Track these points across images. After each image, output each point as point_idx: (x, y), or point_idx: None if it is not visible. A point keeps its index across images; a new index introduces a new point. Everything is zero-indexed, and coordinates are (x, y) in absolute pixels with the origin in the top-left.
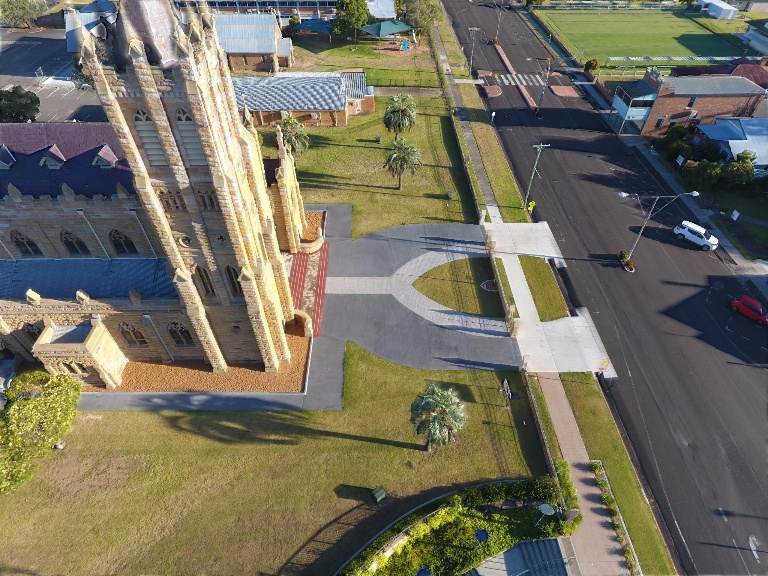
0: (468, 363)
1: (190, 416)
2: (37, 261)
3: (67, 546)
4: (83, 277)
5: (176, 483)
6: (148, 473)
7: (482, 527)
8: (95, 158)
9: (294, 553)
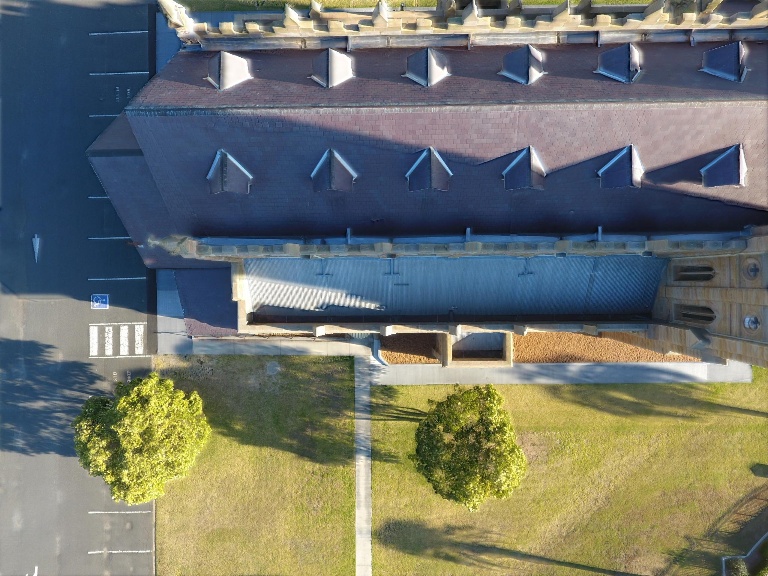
0: None
1: (589, 390)
2: (422, 258)
3: (517, 513)
4: (490, 280)
5: (595, 460)
6: (565, 450)
7: None
8: (620, 186)
9: (721, 524)
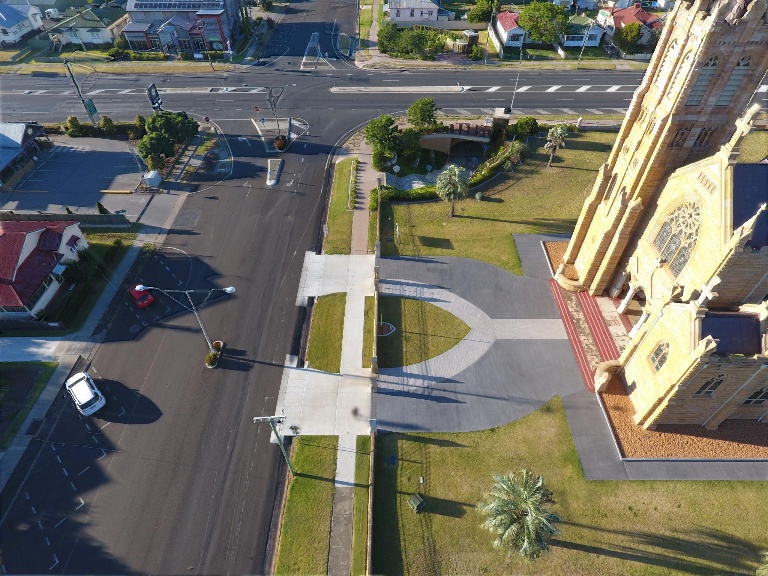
0: (420, 260)
1: None
2: None
3: None
4: None
5: None
6: None
7: (423, 191)
8: None
9: None
